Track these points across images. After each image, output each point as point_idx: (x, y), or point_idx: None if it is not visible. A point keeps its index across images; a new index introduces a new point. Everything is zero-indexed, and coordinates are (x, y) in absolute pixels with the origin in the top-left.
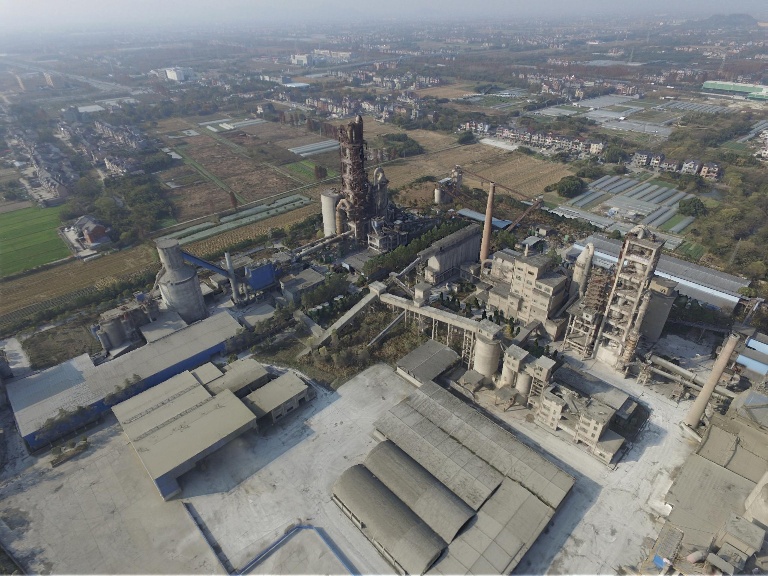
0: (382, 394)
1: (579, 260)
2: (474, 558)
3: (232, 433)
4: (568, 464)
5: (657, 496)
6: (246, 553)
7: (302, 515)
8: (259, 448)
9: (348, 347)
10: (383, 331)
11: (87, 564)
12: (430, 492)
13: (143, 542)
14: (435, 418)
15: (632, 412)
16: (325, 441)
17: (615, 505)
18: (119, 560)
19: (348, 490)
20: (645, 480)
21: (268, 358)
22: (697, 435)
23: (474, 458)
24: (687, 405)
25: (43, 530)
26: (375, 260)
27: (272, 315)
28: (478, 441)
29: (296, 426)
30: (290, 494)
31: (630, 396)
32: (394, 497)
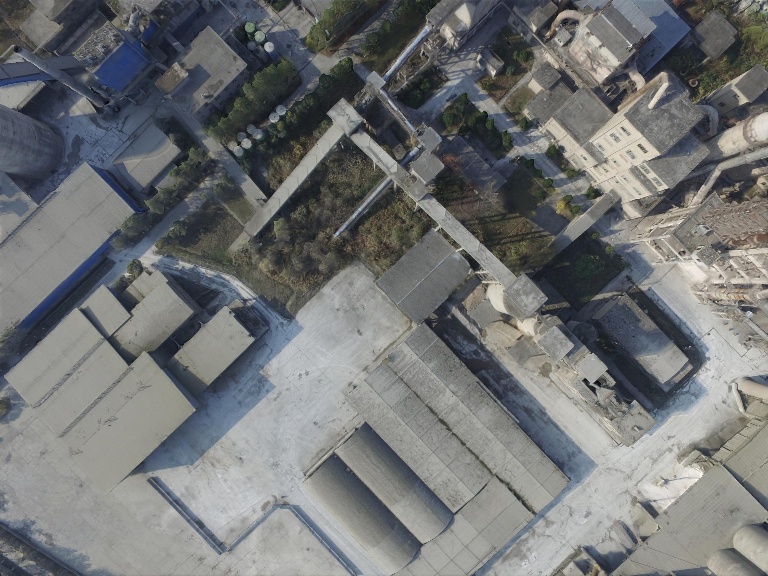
0: (358, 325)
1: (756, 131)
2: (444, 563)
3: (172, 432)
4: (570, 438)
5: (651, 478)
6: (229, 529)
7: (276, 492)
8: (212, 410)
9: (304, 246)
10: (357, 211)
11: (83, 536)
12: (408, 501)
13: (126, 517)
14: (424, 392)
15: (679, 379)
16: (289, 401)
17: (602, 487)
18: (111, 533)
19: (320, 493)
20: (648, 459)
21: (188, 250)
22: (742, 406)
23: (463, 452)
24: (759, 353)
25: (21, 503)
26: (339, 8)
27: (169, 158)
28: (472, 429)
29: (251, 378)
30: (260, 469)
31: (691, 335)
32: (369, 498)
